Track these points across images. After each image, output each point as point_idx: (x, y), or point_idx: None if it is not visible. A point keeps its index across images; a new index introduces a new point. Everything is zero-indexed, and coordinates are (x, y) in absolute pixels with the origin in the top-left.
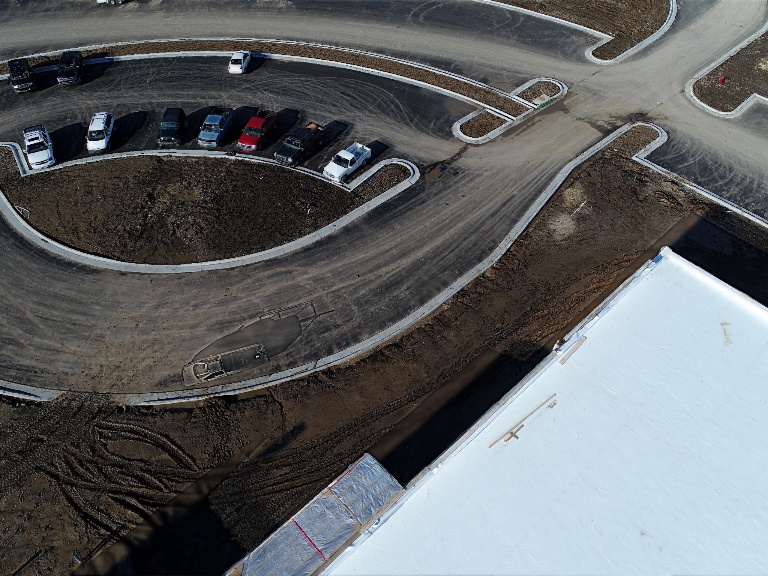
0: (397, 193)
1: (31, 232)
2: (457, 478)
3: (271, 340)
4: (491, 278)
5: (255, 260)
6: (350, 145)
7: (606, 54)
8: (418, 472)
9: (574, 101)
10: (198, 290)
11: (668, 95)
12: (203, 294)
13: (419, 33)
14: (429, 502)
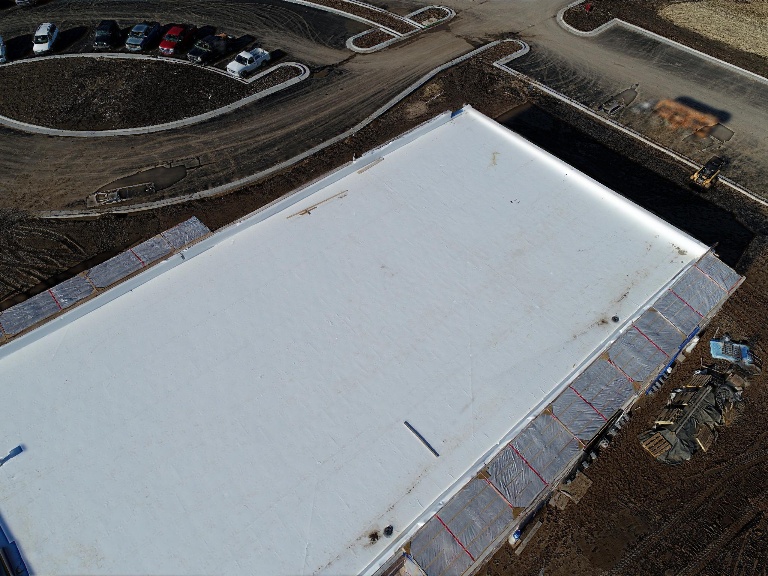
0: (287, 86)
1: None
2: (257, 234)
3: (160, 180)
4: (347, 143)
5: (159, 129)
6: None
7: None
8: (226, 225)
9: (458, 23)
10: (109, 148)
11: (541, 19)
12: (113, 151)
13: None
14: (233, 246)
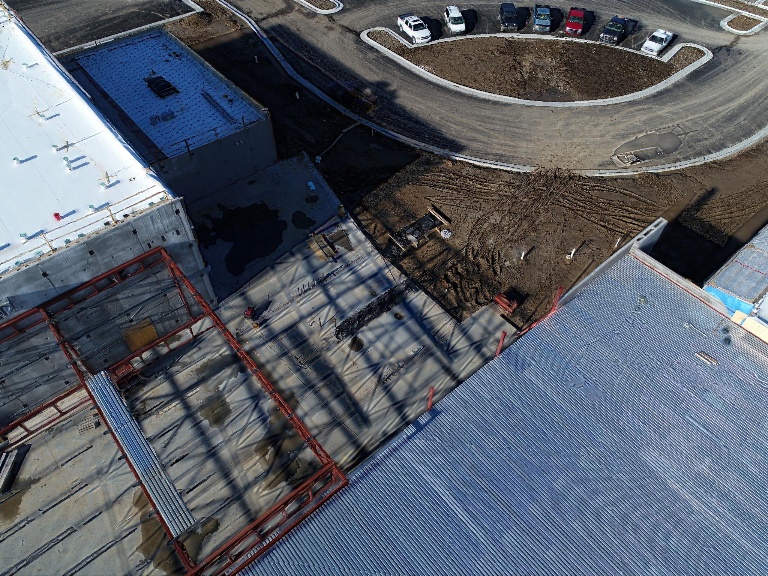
0: (702, 64)
1: (443, 81)
2: None
3: (663, 145)
4: None
5: (620, 101)
6: (647, 34)
7: None
8: None
9: None
10: (590, 117)
11: None
12: (595, 119)
13: None
14: None
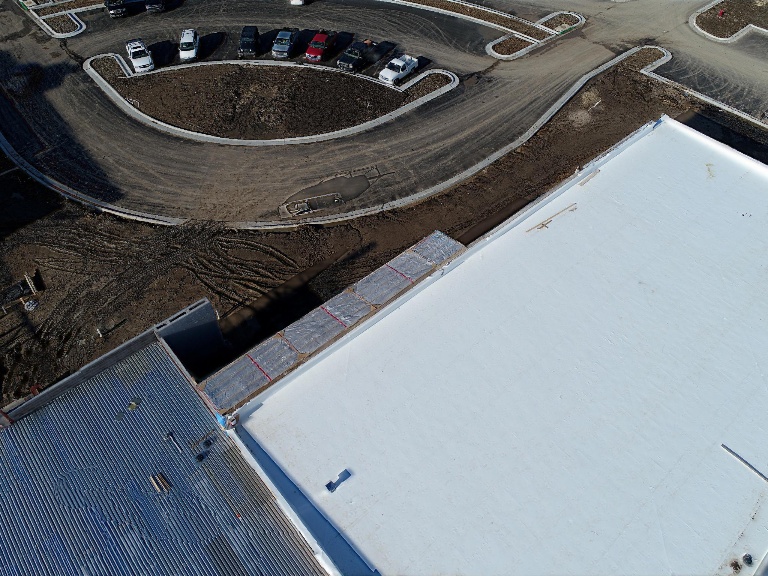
0: (441, 94)
1: (142, 116)
2: (503, 248)
3: (346, 190)
4: (521, 153)
5: (327, 138)
6: None
7: None
8: None
9: (591, 29)
10: (283, 157)
11: (674, 25)
12: (288, 160)
13: None
14: (483, 261)
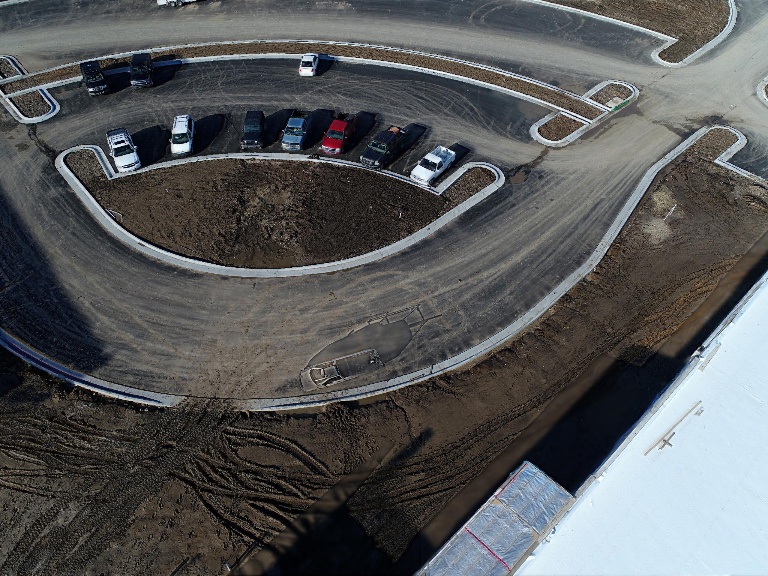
0: (485, 197)
1: (127, 236)
2: (618, 486)
3: (383, 345)
4: (593, 283)
5: (354, 264)
6: (431, 148)
7: (673, 56)
8: None
9: (647, 104)
10: (302, 294)
11: (741, 98)
12: (308, 298)
13: (482, 35)
14: (595, 511)
